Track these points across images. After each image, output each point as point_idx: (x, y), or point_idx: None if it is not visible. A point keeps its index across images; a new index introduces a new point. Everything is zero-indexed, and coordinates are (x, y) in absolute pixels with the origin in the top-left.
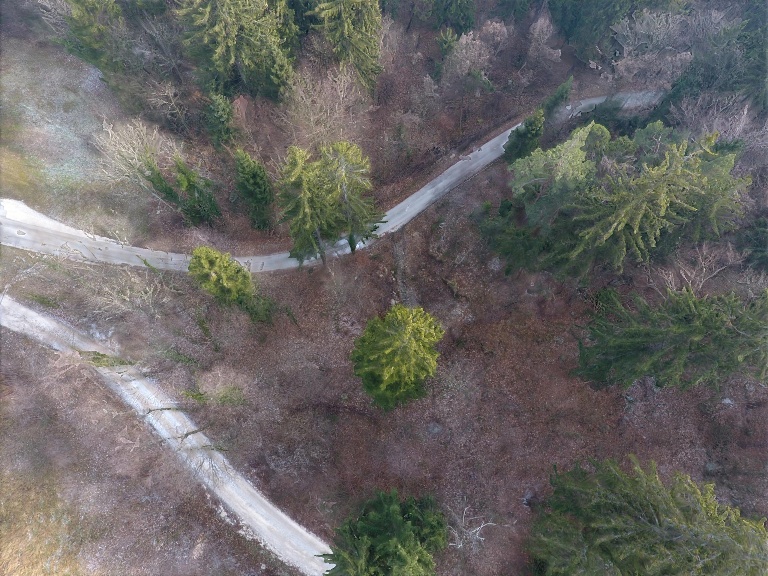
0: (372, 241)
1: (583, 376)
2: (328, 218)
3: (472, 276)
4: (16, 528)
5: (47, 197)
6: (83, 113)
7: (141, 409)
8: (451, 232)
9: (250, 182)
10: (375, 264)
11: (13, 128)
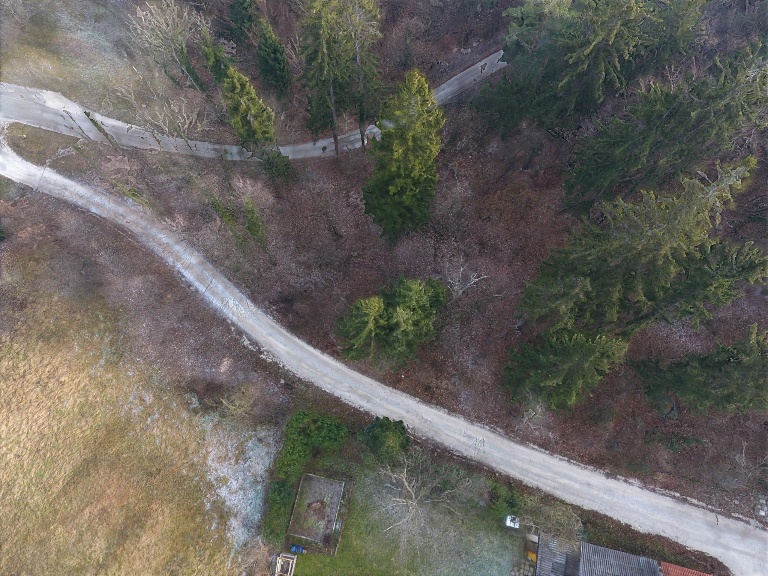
0: None
1: None
2: (342, 74)
3: (472, 159)
4: (64, 341)
5: (82, 91)
6: (113, 23)
7: (171, 260)
8: (453, 126)
9: (271, 56)
10: None
11: (49, 33)
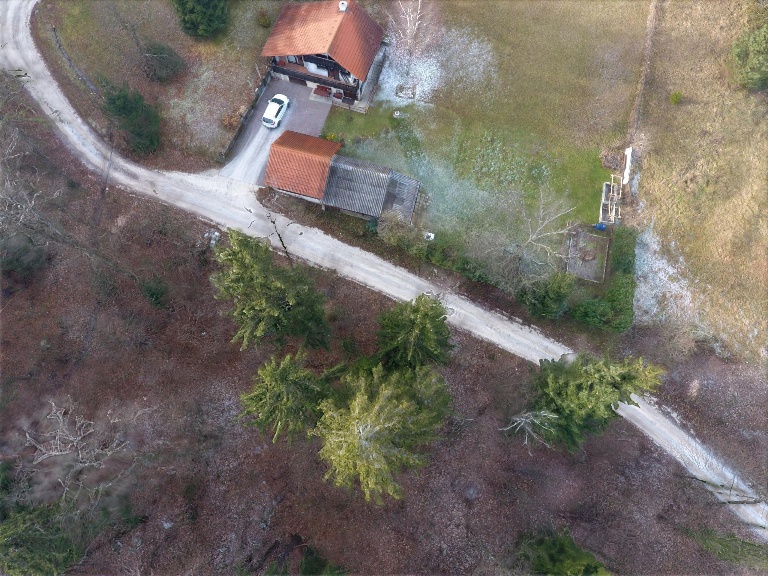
0: None
1: (307, 553)
2: None
3: None
4: None
5: None
6: None
7: None
8: None
9: None
10: None
11: None
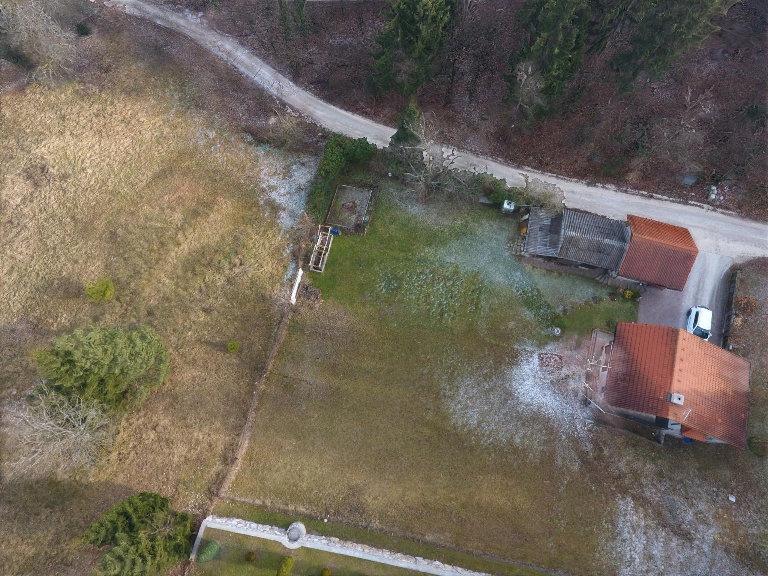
0: None
1: None
2: None
3: None
4: (142, 95)
5: None
6: None
7: (225, 57)
8: None
9: None
10: None
11: None
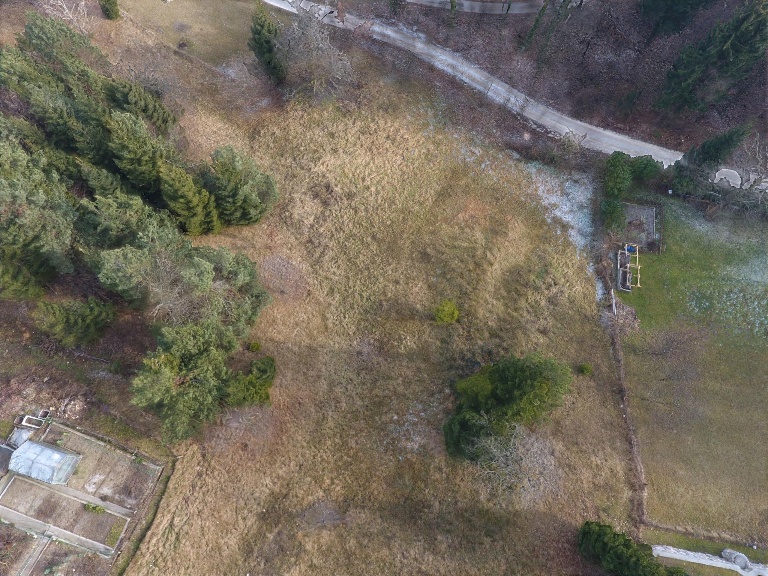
0: (585, 2)
1: None
2: None
3: None
4: (399, 112)
5: None
6: None
7: (452, 71)
8: None
9: None
10: (597, 8)
11: None
